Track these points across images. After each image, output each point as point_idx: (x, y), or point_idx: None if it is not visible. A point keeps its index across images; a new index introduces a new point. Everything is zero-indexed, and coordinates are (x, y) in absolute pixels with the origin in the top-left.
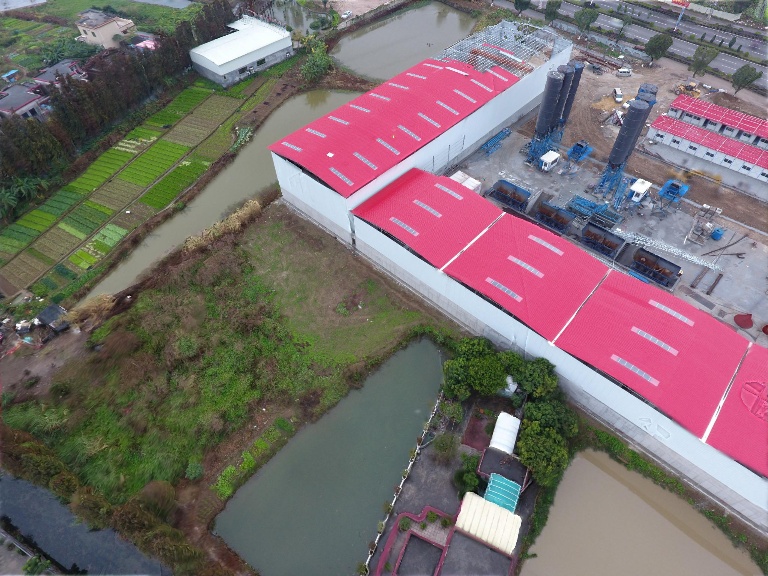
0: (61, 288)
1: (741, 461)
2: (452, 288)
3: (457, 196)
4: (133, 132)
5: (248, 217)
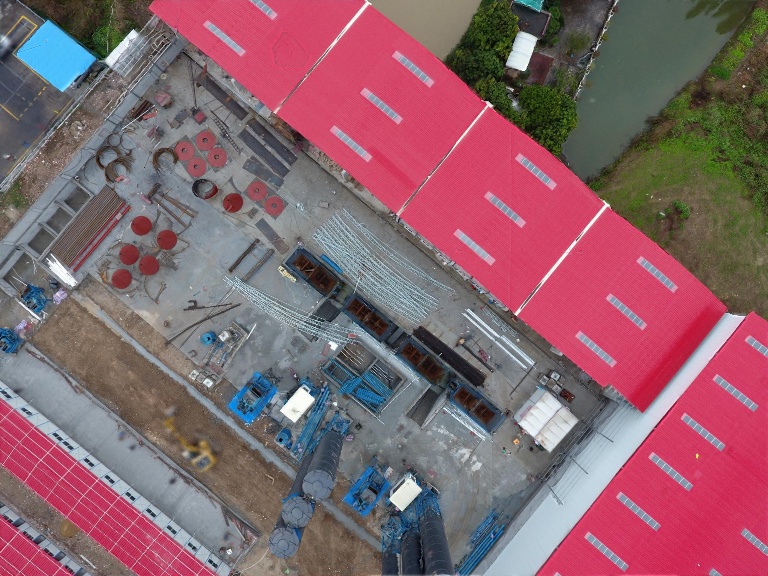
0: None
1: None
2: None
3: (585, 339)
4: None
5: None
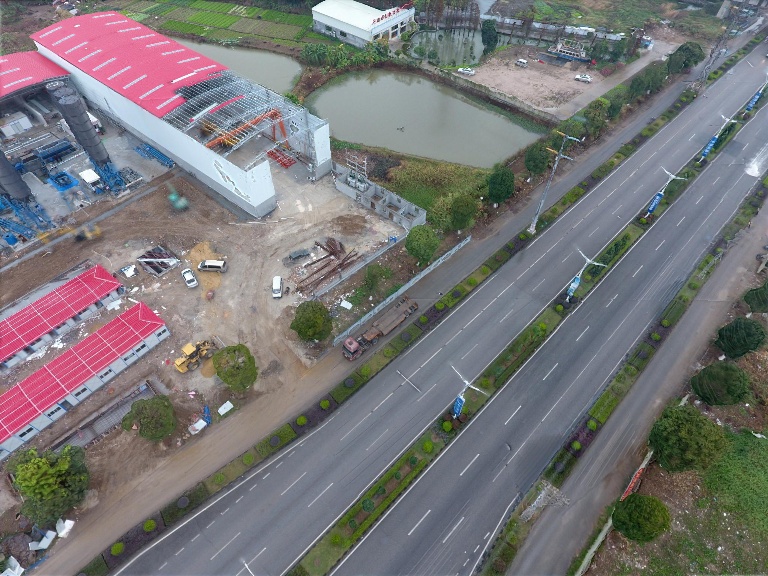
0: None
1: None
2: None
3: (9, 85)
4: (254, 7)
5: None
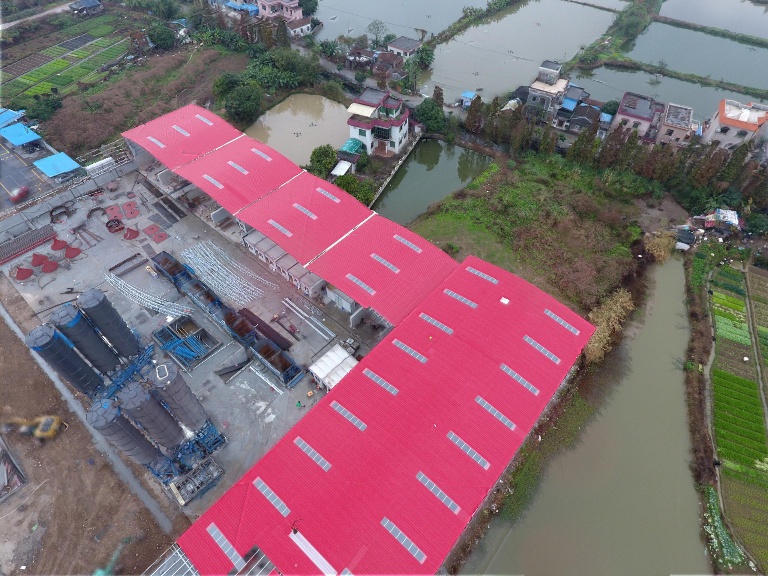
0: (714, 273)
1: (232, 127)
2: None
3: (352, 277)
4: None
5: None
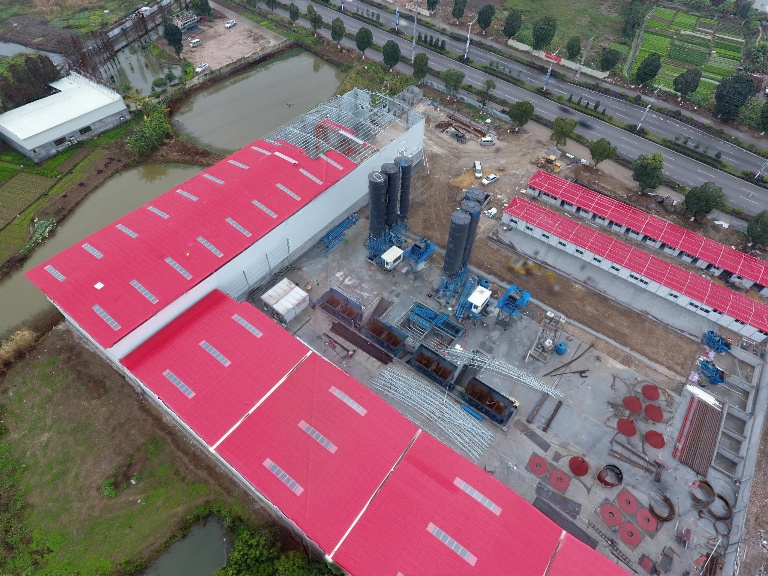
0: None
1: None
2: (231, 467)
3: (256, 332)
4: None
5: (13, 354)
